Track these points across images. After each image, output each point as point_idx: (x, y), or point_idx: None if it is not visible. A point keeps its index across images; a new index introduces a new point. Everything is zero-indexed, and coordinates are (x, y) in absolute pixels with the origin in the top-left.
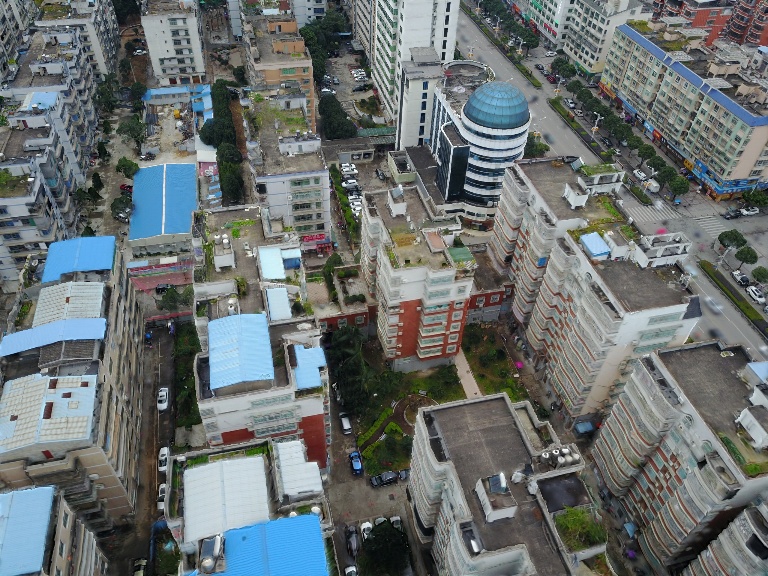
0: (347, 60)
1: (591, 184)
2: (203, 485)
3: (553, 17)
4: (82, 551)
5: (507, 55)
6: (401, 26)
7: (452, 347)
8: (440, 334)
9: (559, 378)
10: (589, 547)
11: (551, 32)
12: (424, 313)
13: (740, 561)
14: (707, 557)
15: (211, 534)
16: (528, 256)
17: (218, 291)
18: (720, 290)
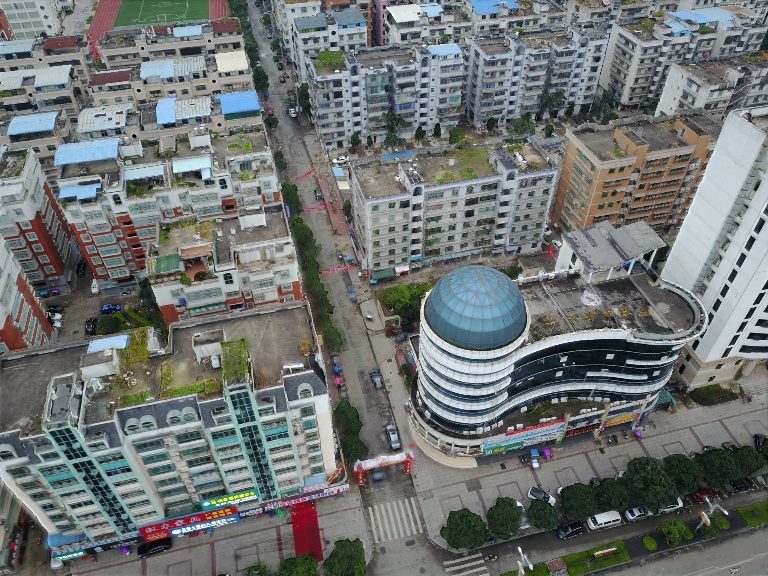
0: None
1: None
2: None
3: None
4: (52, 170)
5: None
6: None
7: None
8: None
9: None
10: None
11: None
12: None
13: None
14: None
15: None
16: None
17: None
18: None
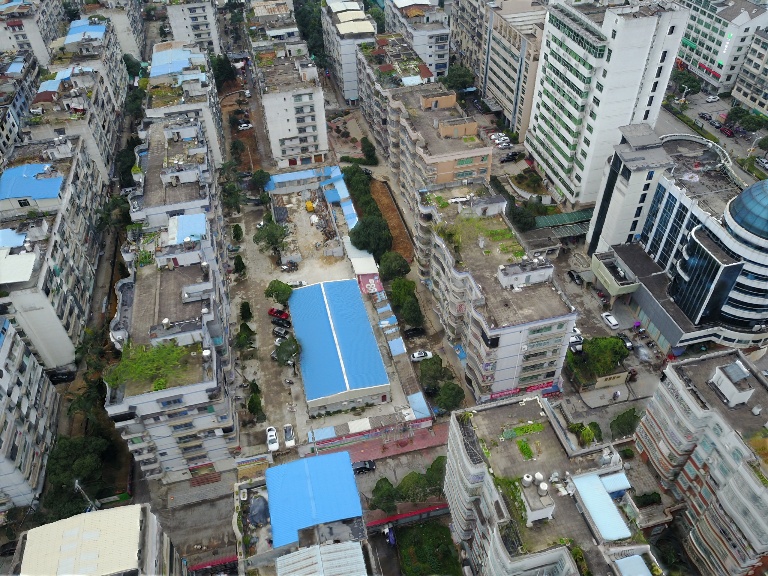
0: (480, 122)
1: None
2: None
3: (714, 57)
4: None
5: (662, 103)
6: (597, 97)
7: None
8: None
9: None
10: None
11: (711, 74)
12: None
13: None
14: None
15: None
16: None
17: (538, 561)
18: None
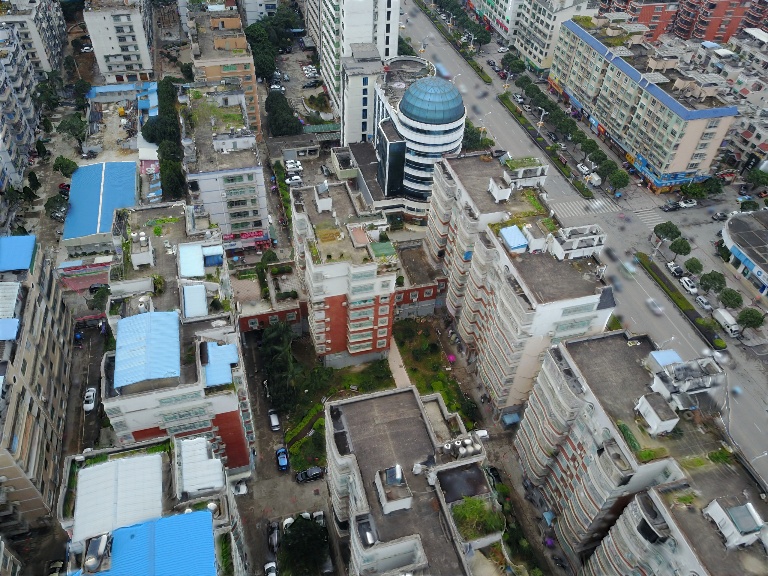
0: (299, 56)
1: (515, 178)
2: (96, 484)
3: (504, 13)
4: None
5: (460, 51)
6: (343, 22)
7: (382, 342)
8: (368, 329)
9: (485, 370)
10: (485, 536)
11: (503, 28)
12: (349, 308)
13: (634, 545)
14: (608, 542)
15: (100, 533)
16: (456, 250)
17: (135, 289)
18: (654, 281)
